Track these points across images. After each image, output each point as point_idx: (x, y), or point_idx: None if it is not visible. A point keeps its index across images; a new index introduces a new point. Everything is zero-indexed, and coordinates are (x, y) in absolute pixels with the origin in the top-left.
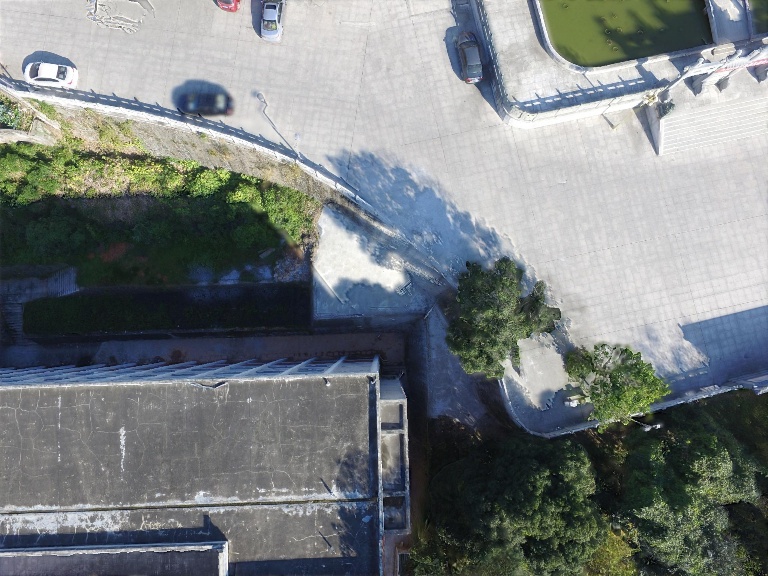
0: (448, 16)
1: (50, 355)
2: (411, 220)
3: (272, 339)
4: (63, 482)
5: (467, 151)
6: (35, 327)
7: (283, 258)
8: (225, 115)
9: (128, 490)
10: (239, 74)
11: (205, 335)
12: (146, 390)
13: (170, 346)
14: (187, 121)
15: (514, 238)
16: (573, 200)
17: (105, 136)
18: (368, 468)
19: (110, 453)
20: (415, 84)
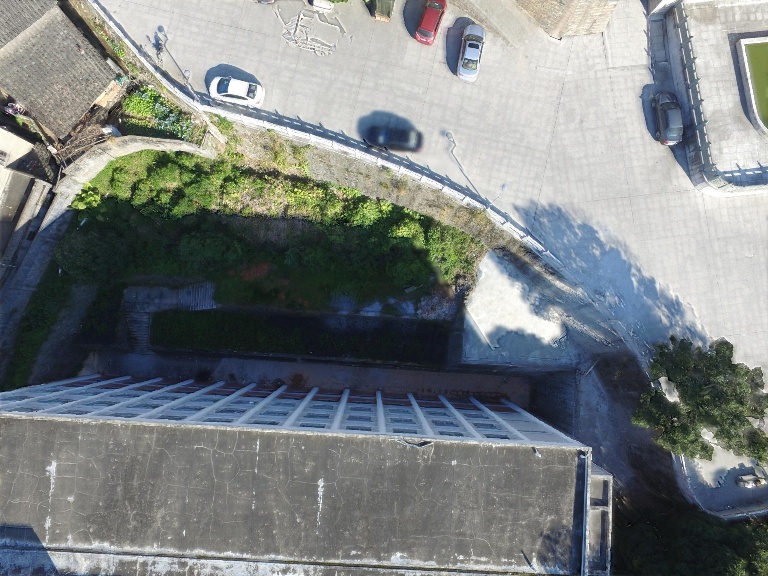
0: (646, 72)
1: (167, 367)
2: (594, 279)
3: (396, 372)
4: (256, 530)
5: (656, 214)
6: (164, 340)
7: (430, 295)
8: (412, 151)
9: (323, 545)
10: (429, 110)
11: (331, 362)
12: (348, 442)
13: (292, 369)
14: (372, 153)
15: (697, 308)
16: (759, 275)
17: (279, 158)
18: (570, 544)
19: (306, 504)
20: (608, 139)
